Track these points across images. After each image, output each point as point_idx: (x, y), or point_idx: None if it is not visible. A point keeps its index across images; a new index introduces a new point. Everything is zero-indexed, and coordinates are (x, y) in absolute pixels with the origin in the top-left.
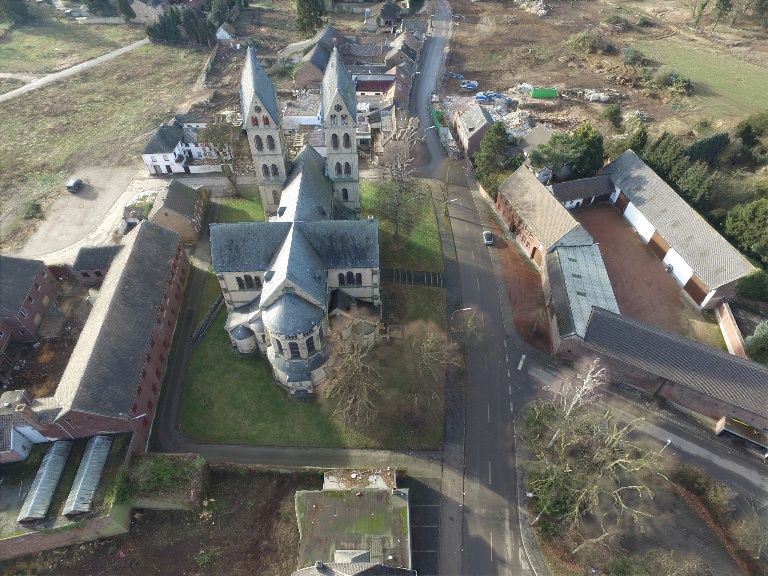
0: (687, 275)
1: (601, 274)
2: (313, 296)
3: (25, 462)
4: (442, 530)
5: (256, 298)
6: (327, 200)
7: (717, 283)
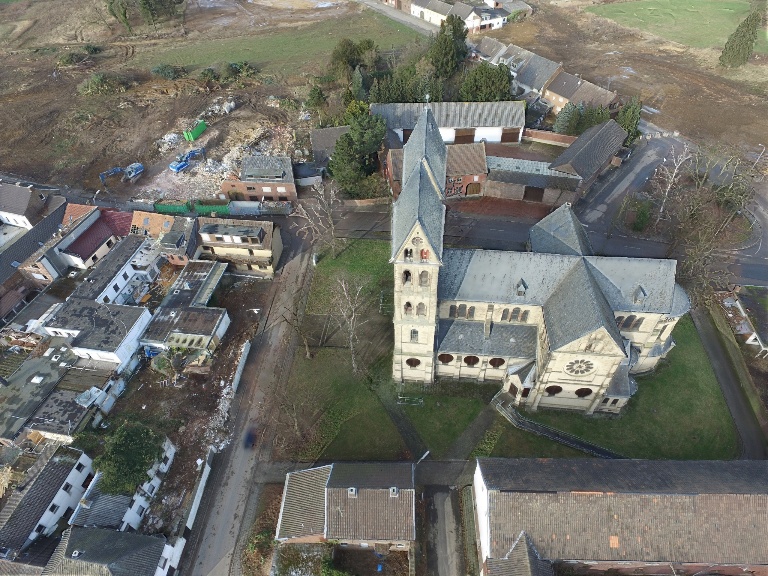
0: (499, 134)
1: (510, 160)
2: None
3: None
4: (733, 283)
5: None
6: None
7: (522, 121)
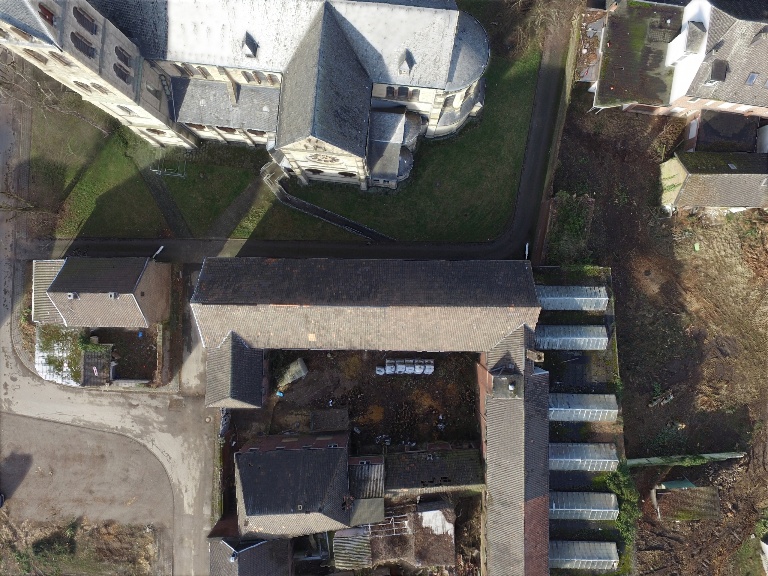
0: None
1: None
2: (454, 3)
3: (541, 367)
4: None
5: (370, 129)
6: None
7: None
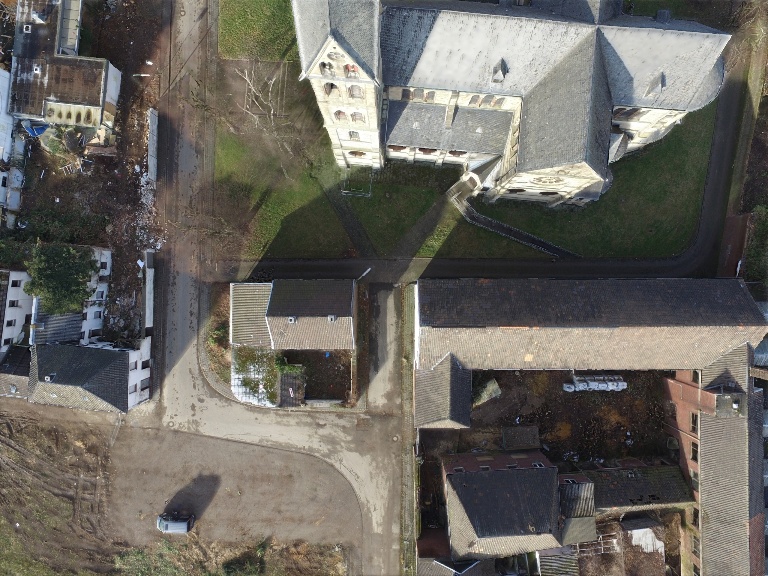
0: None
1: None
2: None
3: None
4: None
5: None
6: (459, 2)
7: None
